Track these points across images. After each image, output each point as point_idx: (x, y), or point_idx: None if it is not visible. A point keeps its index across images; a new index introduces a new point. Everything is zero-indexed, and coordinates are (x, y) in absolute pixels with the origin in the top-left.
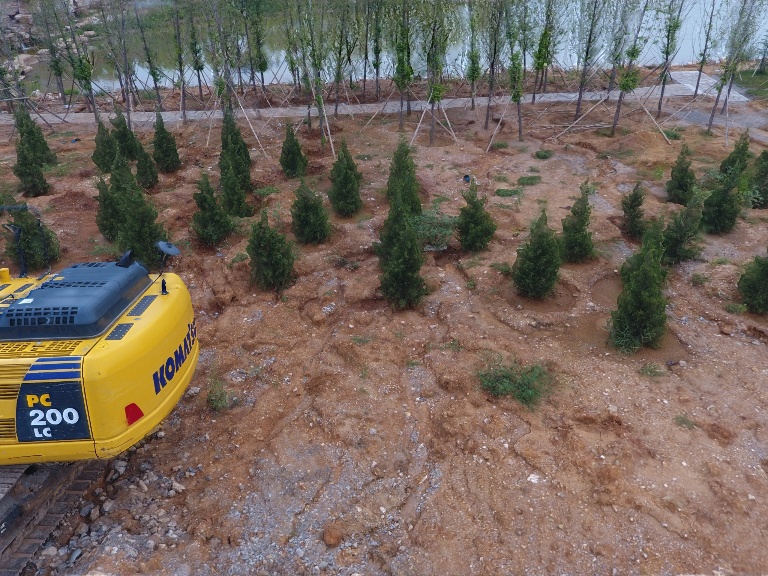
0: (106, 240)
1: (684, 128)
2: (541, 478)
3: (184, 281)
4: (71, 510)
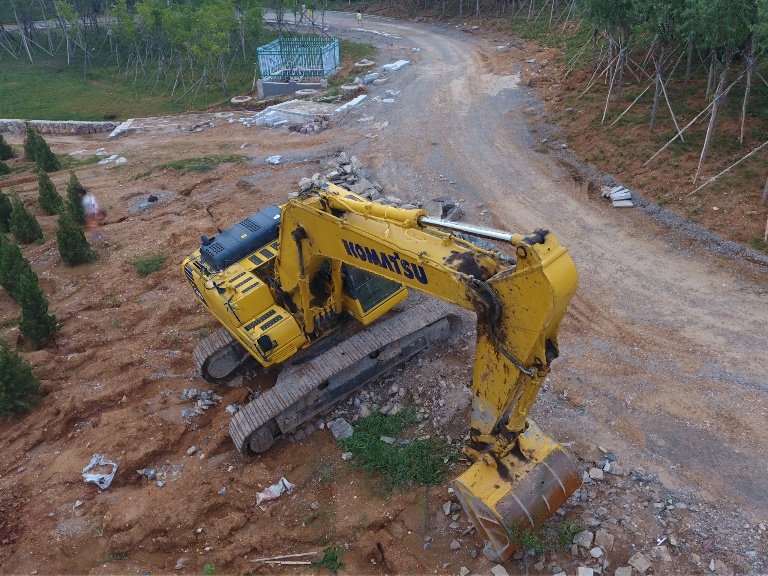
0: None
1: None
2: None
3: (16, 477)
4: None
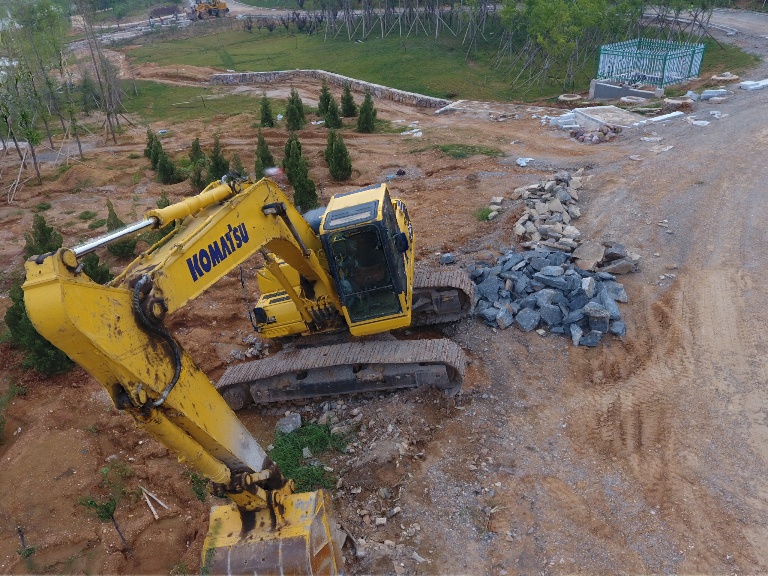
0: None
1: None
2: None
3: None
4: None
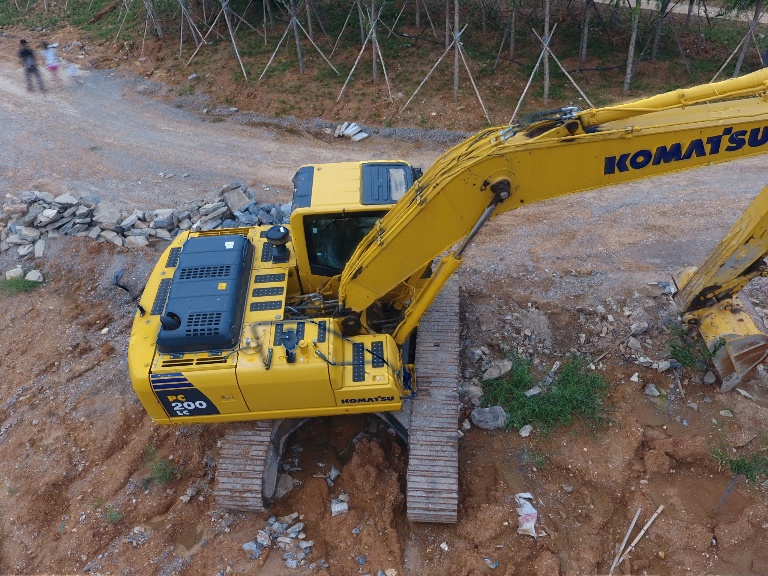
0: None
1: None
2: None
3: None
4: None
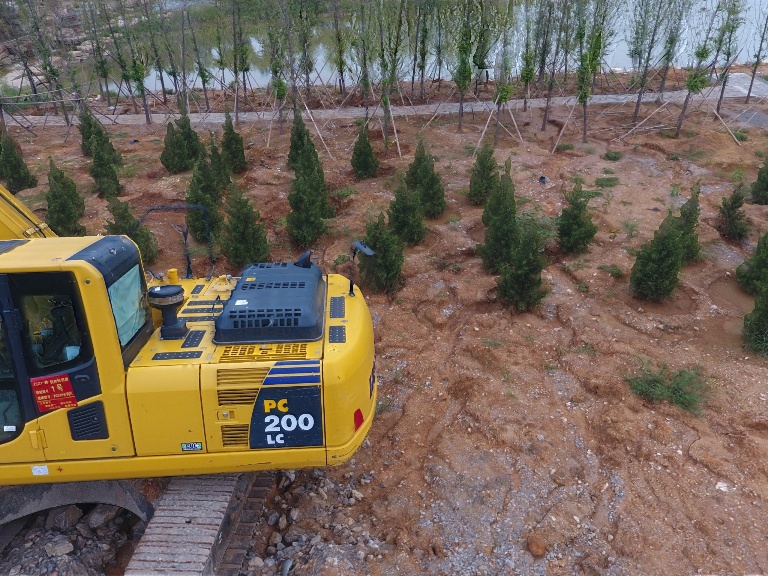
0: (195, 241)
1: (747, 130)
2: (730, 486)
3: None
4: (258, 518)
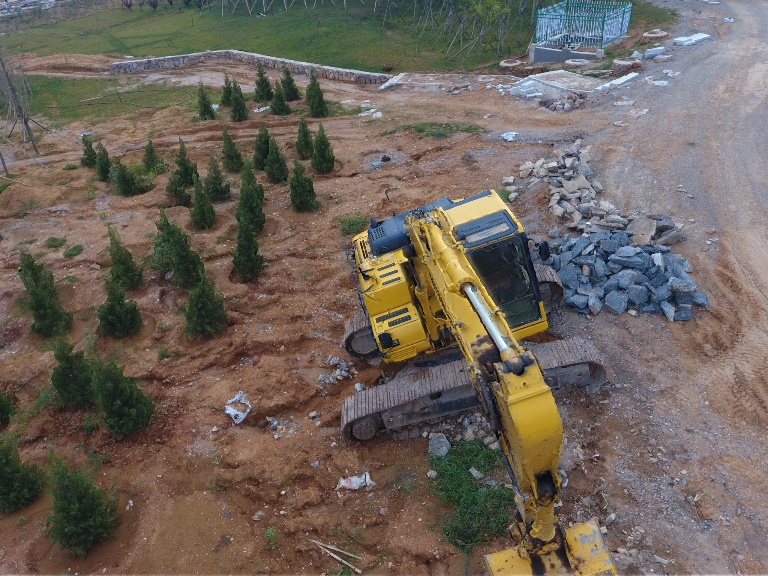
0: (29, 506)
1: None
2: None
3: (184, 389)
4: None
